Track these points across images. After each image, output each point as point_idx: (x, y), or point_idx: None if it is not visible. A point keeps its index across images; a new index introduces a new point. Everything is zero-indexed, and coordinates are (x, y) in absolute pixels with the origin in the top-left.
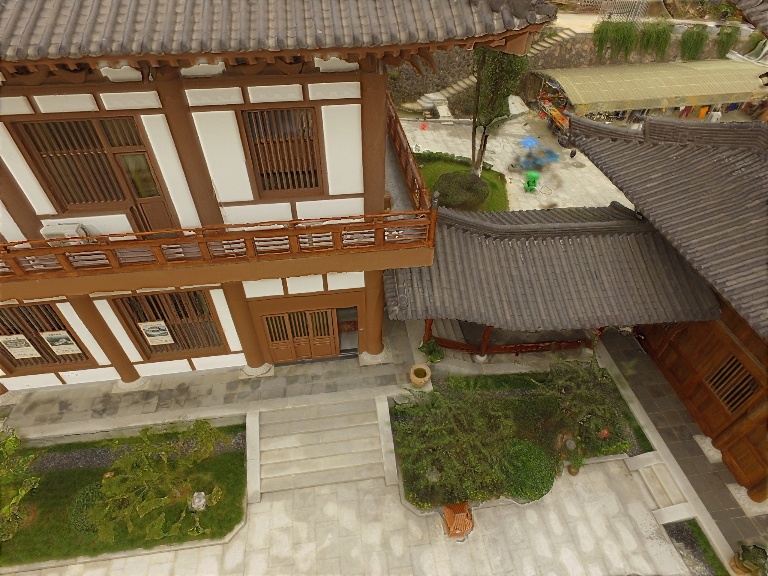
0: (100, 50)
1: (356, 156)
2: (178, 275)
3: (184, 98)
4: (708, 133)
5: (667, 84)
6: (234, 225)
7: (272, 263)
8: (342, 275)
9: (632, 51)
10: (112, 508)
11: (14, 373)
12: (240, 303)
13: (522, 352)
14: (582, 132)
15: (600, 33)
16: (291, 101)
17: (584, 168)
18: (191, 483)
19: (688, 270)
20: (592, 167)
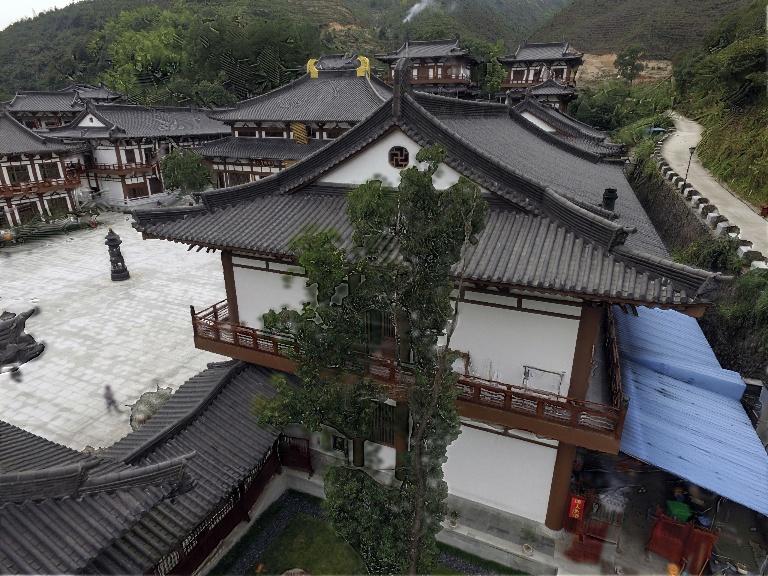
0: None
1: None
2: None
3: None
4: None
5: None
6: None
7: None
8: None
9: None
10: None
11: None
12: None
13: None
14: None
15: None
16: None
17: None
18: None
19: None
20: None
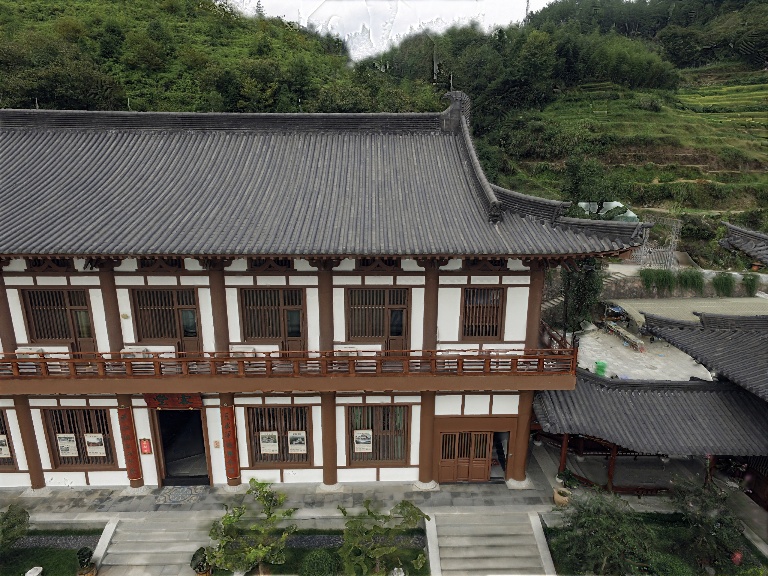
0: (436, 251)
1: (523, 317)
2: (412, 382)
3: (437, 280)
4: (749, 322)
5: (711, 311)
6: (454, 350)
7: (471, 378)
8: (503, 402)
9: (674, 289)
10: (333, 571)
11: (254, 466)
12: (430, 418)
13: (643, 495)
14: (656, 324)
15: (645, 276)
16: (492, 284)
17: (657, 370)
18: (386, 565)
19: (767, 417)
20: (664, 369)
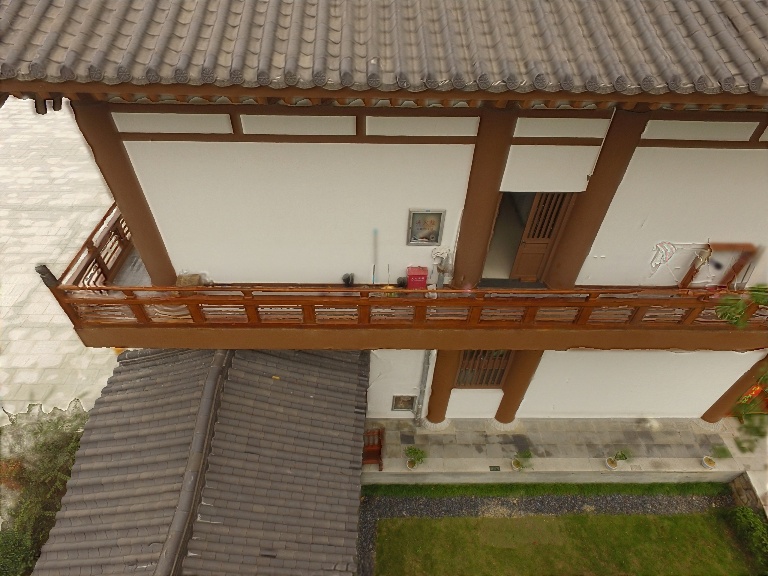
0: None
1: None
2: None
3: None
4: None
5: None
6: None
7: None
8: None
9: None
10: None
11: None
12: None
13: None
14: None
15: None
16: None
17: None
18: None
19: None
20: None
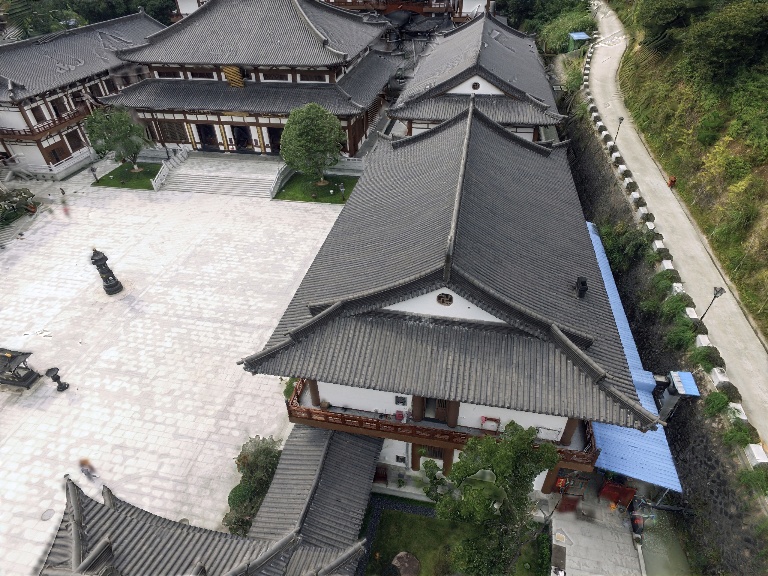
0: None
1: None
2: None
3: None
4: None
5: None
6: None
7: None
8: None
9: None
10: None
11: None
12: None
13: None
14: None
15: None
16: None
17: None
18: None
19: None
20: None
